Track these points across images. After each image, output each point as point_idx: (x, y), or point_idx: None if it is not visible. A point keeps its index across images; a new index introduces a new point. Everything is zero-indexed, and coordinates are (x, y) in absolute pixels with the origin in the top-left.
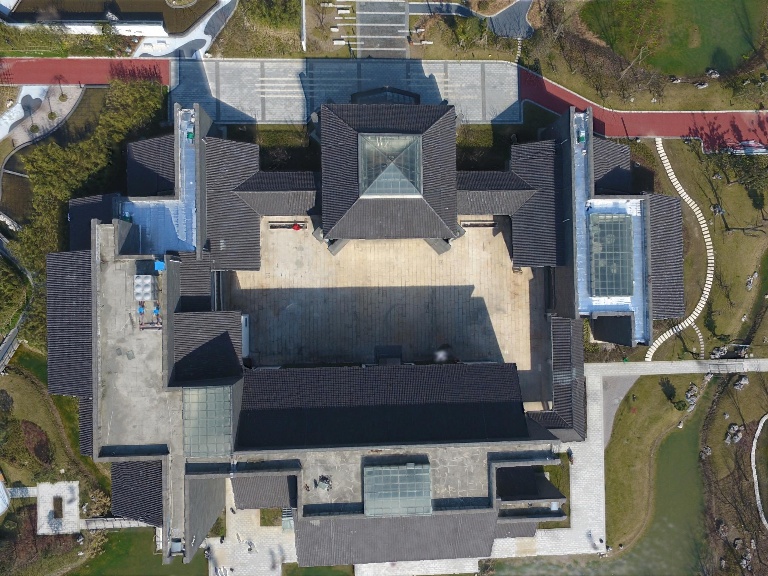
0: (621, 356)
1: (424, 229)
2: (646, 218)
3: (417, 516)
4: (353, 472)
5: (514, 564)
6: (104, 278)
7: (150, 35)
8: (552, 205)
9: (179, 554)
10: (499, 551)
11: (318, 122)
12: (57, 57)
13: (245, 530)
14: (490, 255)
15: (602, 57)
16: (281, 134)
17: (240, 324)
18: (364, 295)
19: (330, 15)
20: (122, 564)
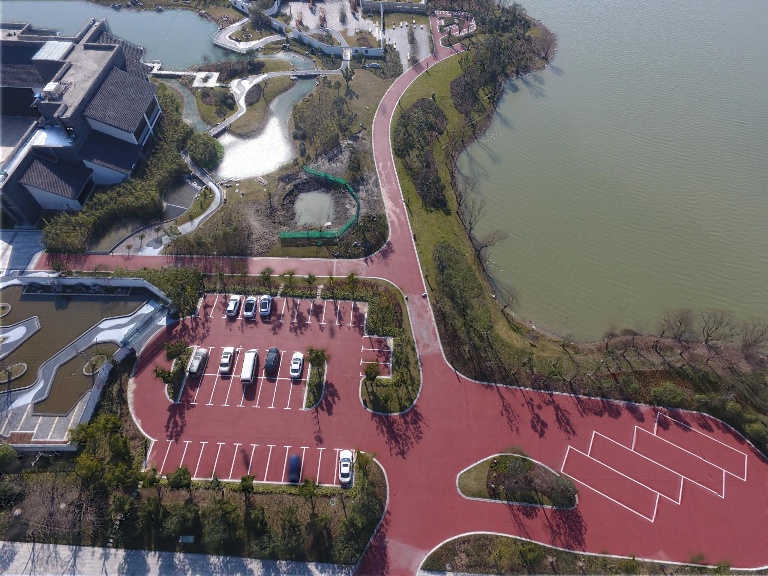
0: None
1: None
2: None
3: None
4: None
5: None
6: None
7: None
8: None
9: None
10: None
11: None
12: None
13: None
14: None
15: None
16: None
17: None
18: None
19: None
20: (184, 64)
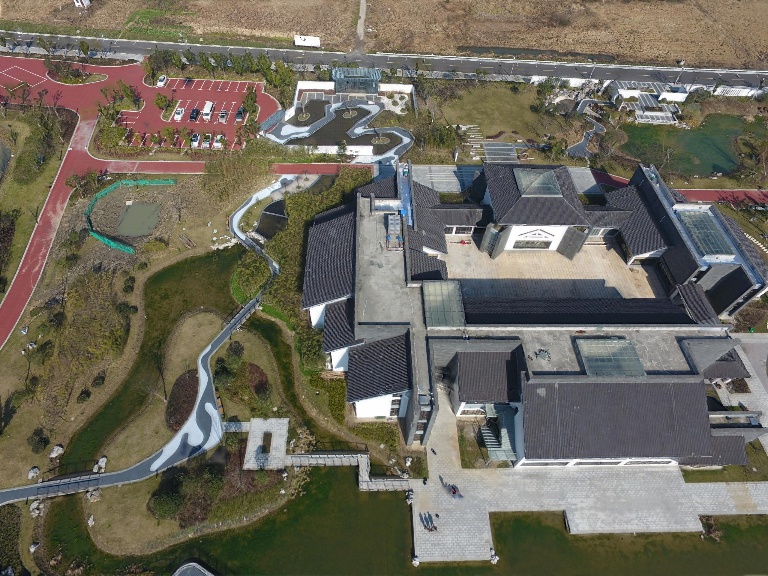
0: (746, 327)
1: (566, 219)
2: (718, 214)
3: (632, 390)
4: (566, 347)
5: (739, 525)
6: (362, 224)
7: (362, 154)
8: (648, 216)
9: (427, 407)
10: (716, 505)
11: (480, 174)
12: (305, 163)
13: (447, 472)
14: (609, 261)
15: None
16: (446, 196)
17: (446, 269)
18: (521, 284)
19: (468, 148)
20: (320, 510)
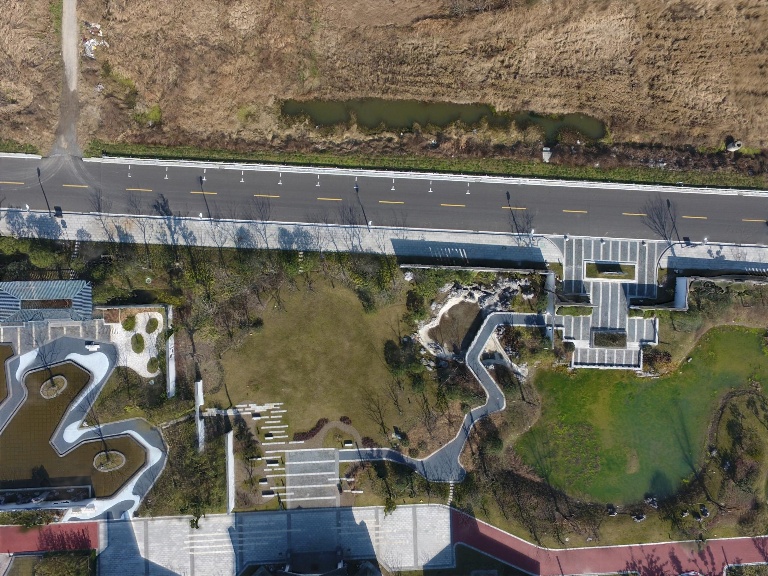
0: None
1: None
2: None
3: None
4: None
5: None
6: None
7: None
8: None
9: None
10: None
11: None
12: None
13: None
14: None
15: (536, 498)
16: None
17: None
18: None
19: (259, 467)
20: None
